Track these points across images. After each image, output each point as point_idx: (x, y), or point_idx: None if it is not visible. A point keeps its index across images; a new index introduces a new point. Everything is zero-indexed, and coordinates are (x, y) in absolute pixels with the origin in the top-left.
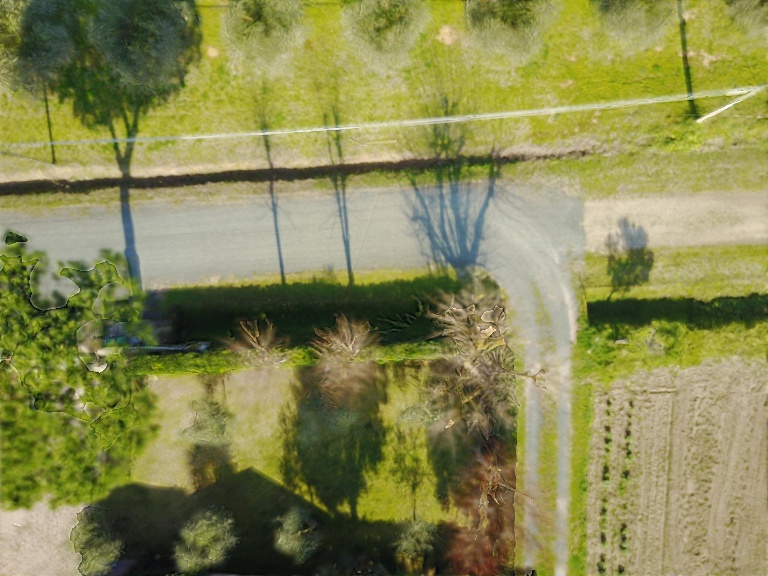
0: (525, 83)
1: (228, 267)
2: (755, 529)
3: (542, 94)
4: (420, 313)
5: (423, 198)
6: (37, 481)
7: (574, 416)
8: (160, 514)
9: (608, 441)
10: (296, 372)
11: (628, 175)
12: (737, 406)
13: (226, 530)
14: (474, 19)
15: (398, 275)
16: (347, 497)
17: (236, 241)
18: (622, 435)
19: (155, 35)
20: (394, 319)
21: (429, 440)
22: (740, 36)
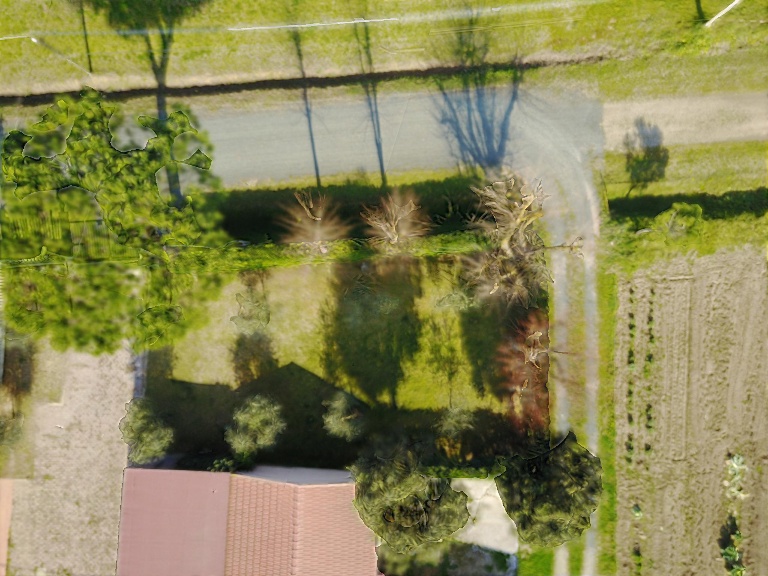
0: None
1: (265, 171)
2: None
3: (561, 3)
4: (450, 214)
5: (451, 102)
6: (79, 383)
7: (599, 304)
8: (203, 411)
9: (632, 327)
10: (333, 270)
11: (643, 77)
12: (750, 290)
13: (273, 416)
14: None
15: (429, 176)
16: (385, 389)
17: (272, 146)
18: (645, 321)
19: None
20: (425, 220)
21: (463, 331)
22: None
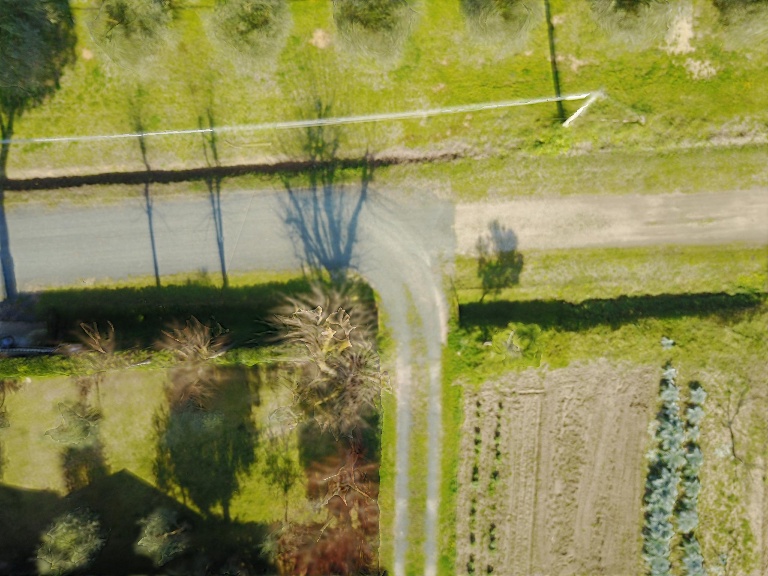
0: (397, 87)
1: (103, 269)
2: (621, 529)
3: (414, 97)
4: None
5: (297, 200)
6: None
7: (444, 417)
8: (33, 517)
9: (477, 442)
10: (169, 374)
11: (498, 178)
12: (604, 407)
13: (90, 532)
14: (339, 23)
15: (272, 277)
16: (220, 499)
17: (111, 243)
18: (491, 436)
19: (17, 37)
20: (271, 321)
21: (301, 442)
22: (605, 41)
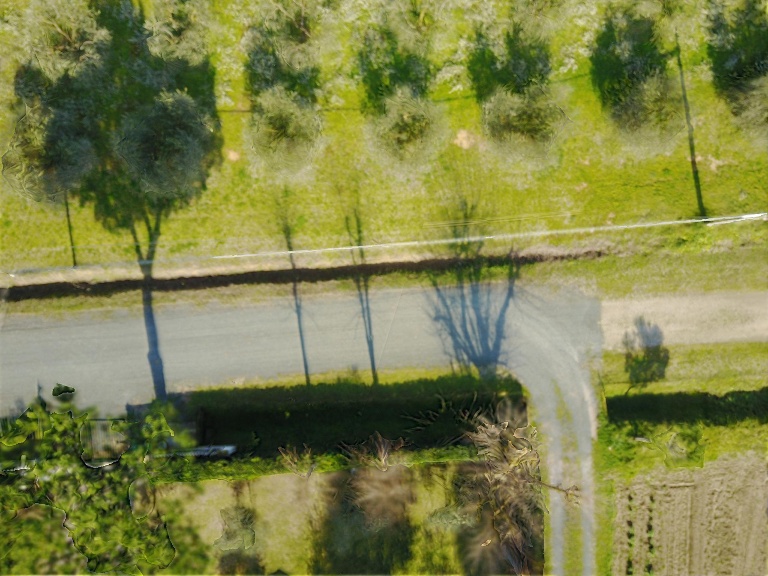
0: (542, 186)
1: (252, 369)
2: None
3: (558, 197)
4: (443, 410)
5: (445, 298)
6: None
7: (597, 512)
8: None
9: (630, 536)
10: (322, 474)
11: (643, 275)
12: (753, 499)
13: None
14: (494, 130)
15: (421, 374)
16: None
17: (260, 343)
18: (644, 529)
19: (182, 149)
20: (417, 416)
21: (455, 539)
22: (745, 143)
